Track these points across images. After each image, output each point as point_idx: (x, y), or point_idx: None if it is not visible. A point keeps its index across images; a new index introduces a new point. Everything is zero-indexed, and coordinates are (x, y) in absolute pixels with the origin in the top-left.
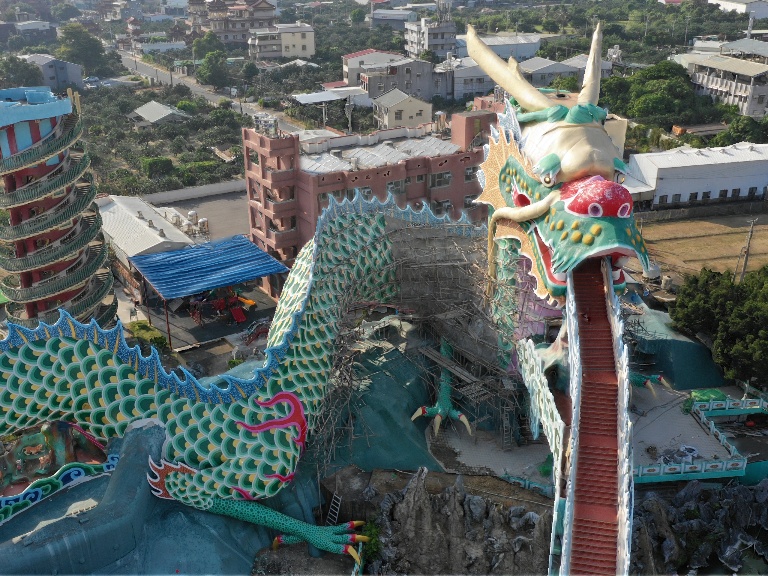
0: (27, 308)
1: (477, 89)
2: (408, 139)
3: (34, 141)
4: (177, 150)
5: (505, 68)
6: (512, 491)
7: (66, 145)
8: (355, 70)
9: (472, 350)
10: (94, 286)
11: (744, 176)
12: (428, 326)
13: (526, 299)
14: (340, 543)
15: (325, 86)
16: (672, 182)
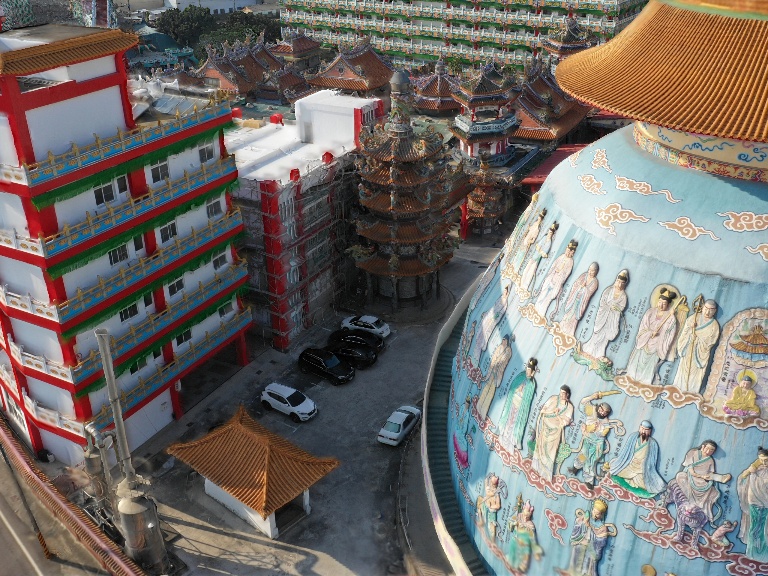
0: None
1: None
2: None
3: None
4: None
5: None
6: None
7: None
8: None
9: None
10: None
11: (224, 1)
12: None
13: (84, 4)
14: None
15: None
16: (186, 6)
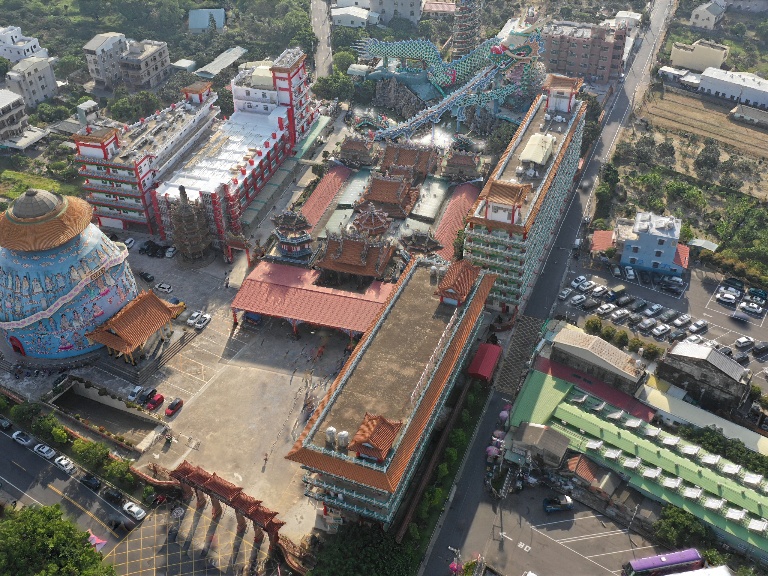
0: None
1: None
2: None
3: (466, 1)
4: (590, 4)
5: None
6: None
7: (471, 4)
8: None
9: None
10: None
11: None
12: None
13: None
14: None
15: None
16: None
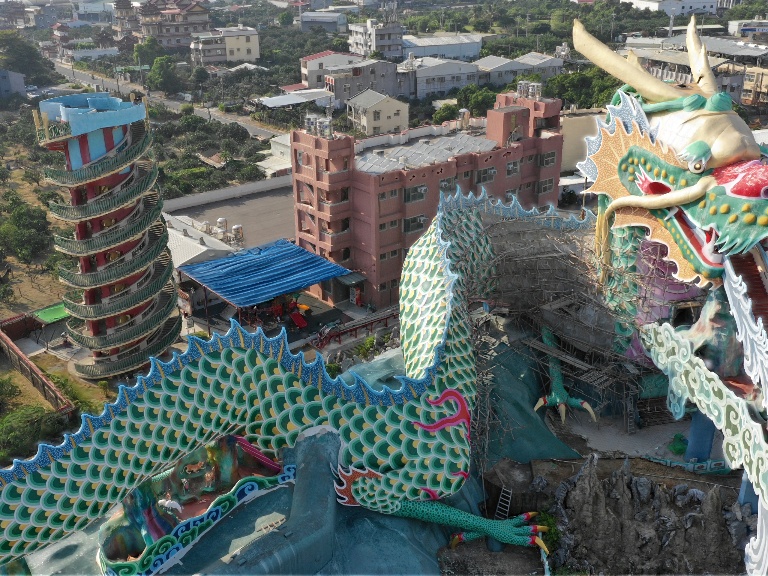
0: (92, 325)
1: (439, 88)
2: (436, 137)
3: (108, 149)
4: (159, 158)
5: (624, 60)
6: (665, 471)
7: (141, 152)
8: (315, 72)
9: (583, 338)
10: (160, 298)
11: None
12: (526, 318)
13: (650, 284)
14: (523, 535)
15: (285, 89)
16: None
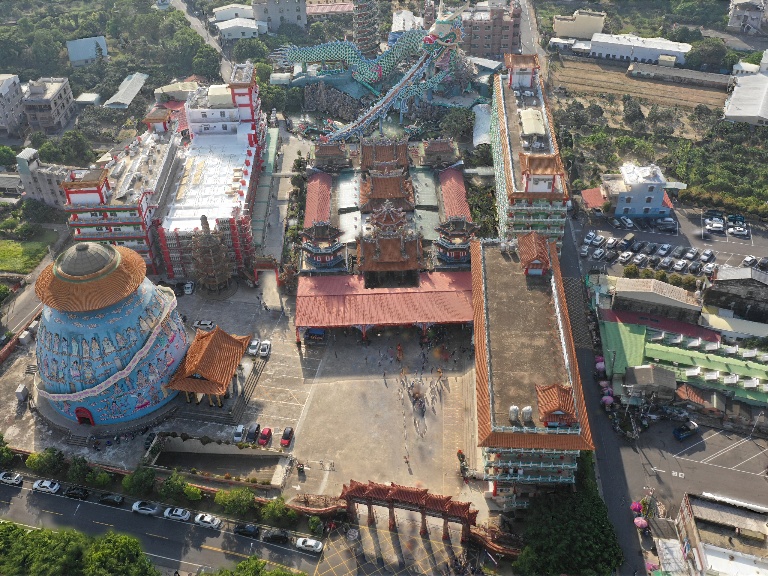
0: (358, 40)
1: None
2: (486, 11)
3: None
4: None
5: None
6: None
7: None
8: None
9: None
10: None
11: None
12: None
13: None
14: None
15: None
16: None
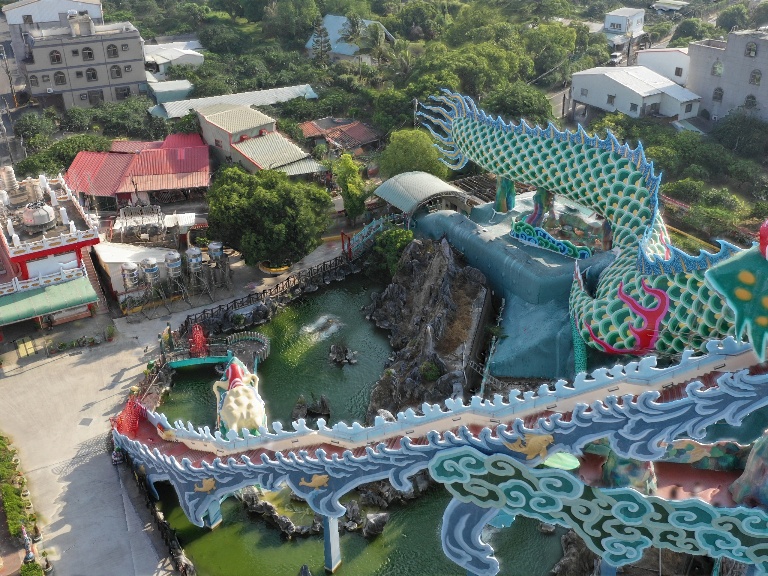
0: None
1: None
2: None
3: None
4: None
5: None
6: None
7: None
8: None
9: None
10: None
11: None
12: None
13: None
14: None
15: None
16: None
